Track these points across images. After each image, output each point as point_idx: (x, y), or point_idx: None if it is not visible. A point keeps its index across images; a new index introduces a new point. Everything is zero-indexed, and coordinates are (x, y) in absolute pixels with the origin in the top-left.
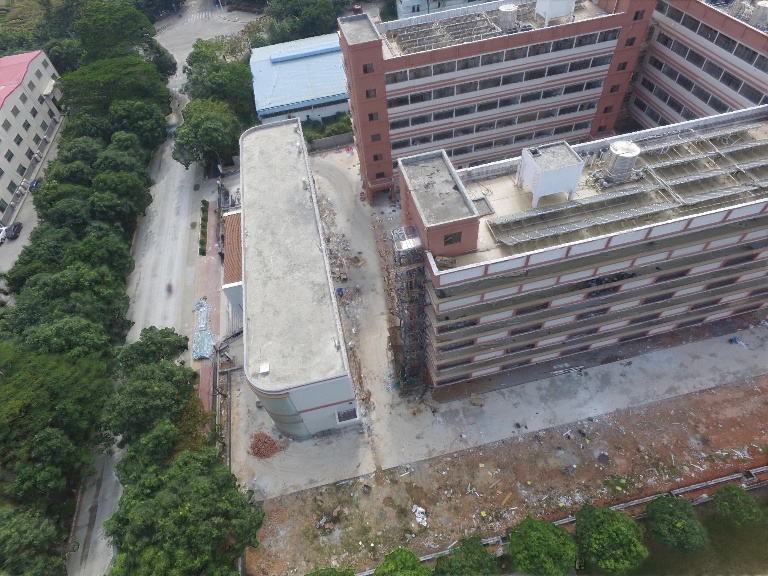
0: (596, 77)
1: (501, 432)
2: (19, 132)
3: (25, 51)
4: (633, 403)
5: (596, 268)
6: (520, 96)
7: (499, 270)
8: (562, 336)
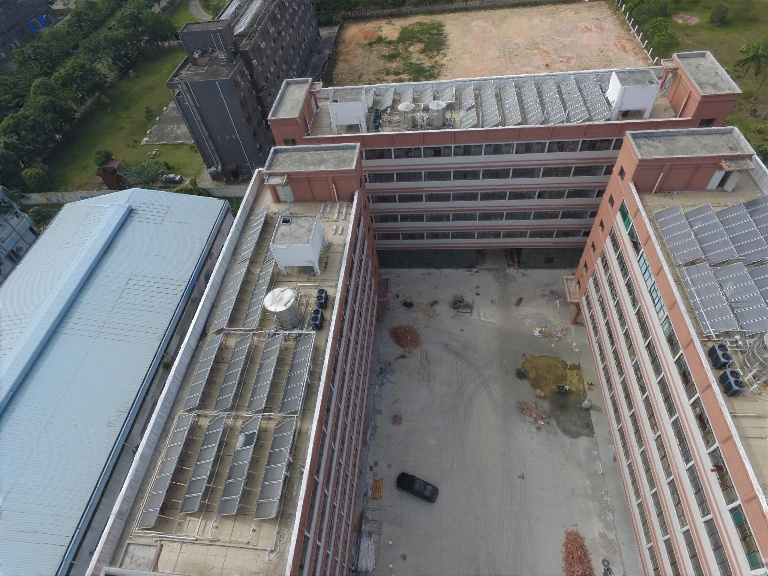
0: None
1: None
2: None
3: None
4: None
5: None
6: None
7: None
8: None
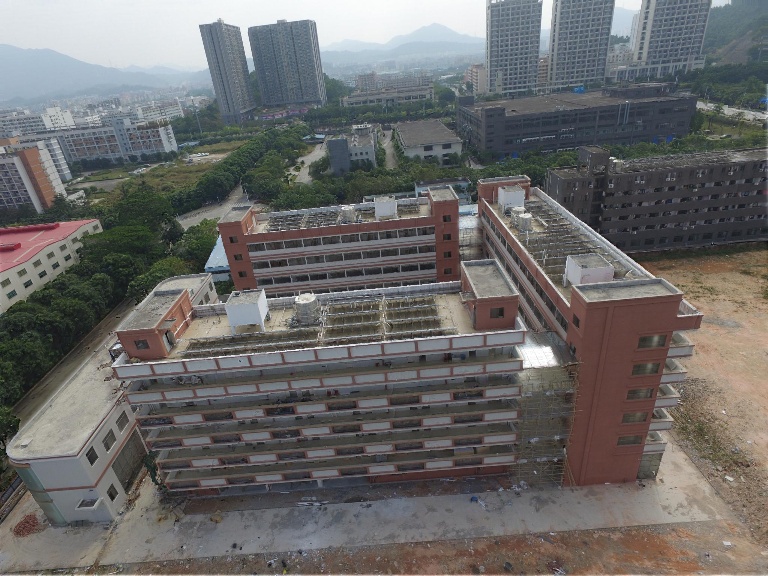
0: (426, 261)
1: (217, 549)
2: (46, 269)
3: None
4: (348, 543)
5: (256, 384)
6: (363, 270)
7: (166, 372)
8: (270, 454)
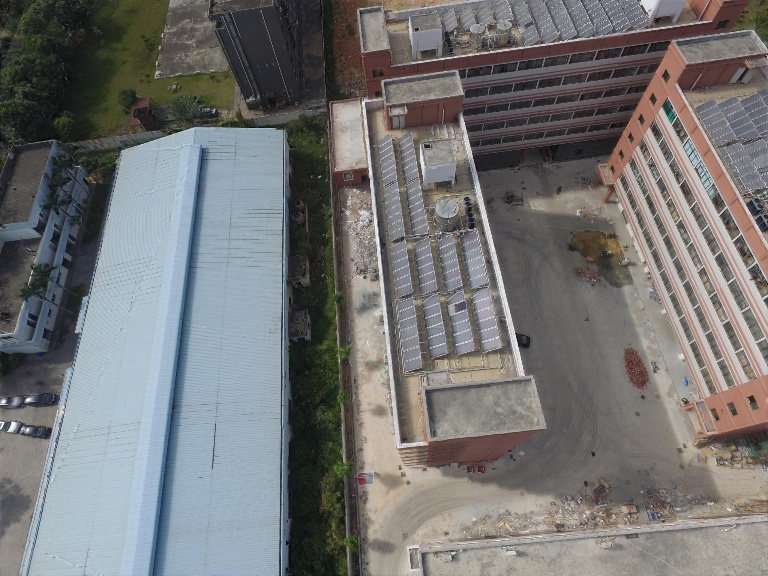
0: None
1: None
2: None
3: None
4: None
5: None
6: None
7: None
8: None
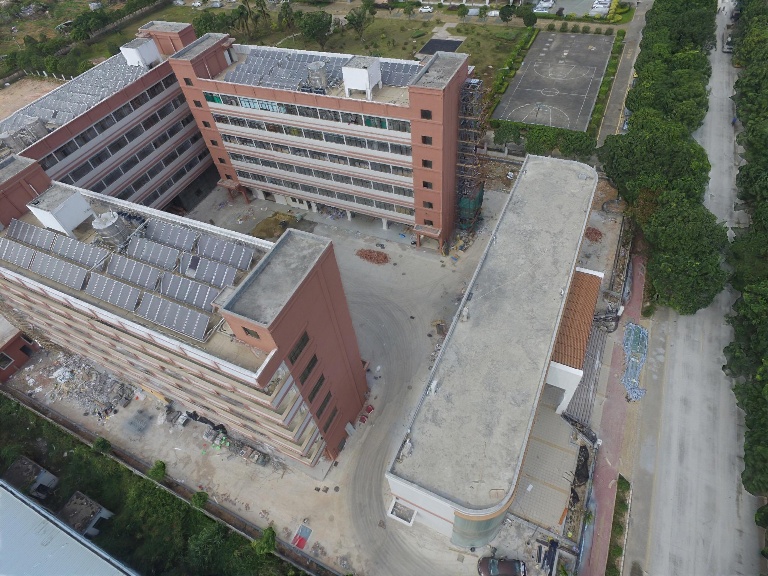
0: None
1: None
2: None
3: None
4: None
5: None
6: None
7: None
8: None
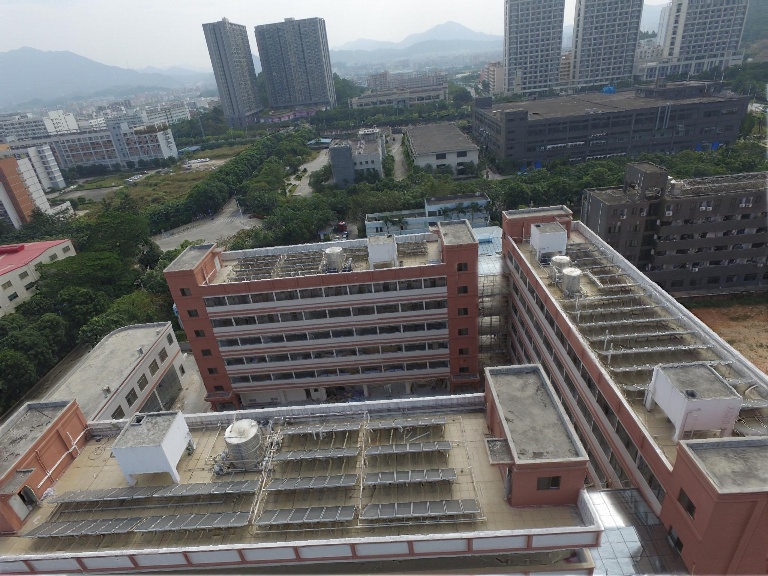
0: (435, 319)
1: None
2: (0, 302)
3: (67, 238)
4: None
5: None
6: (354, 329)
7: (1, 571)
8: None
